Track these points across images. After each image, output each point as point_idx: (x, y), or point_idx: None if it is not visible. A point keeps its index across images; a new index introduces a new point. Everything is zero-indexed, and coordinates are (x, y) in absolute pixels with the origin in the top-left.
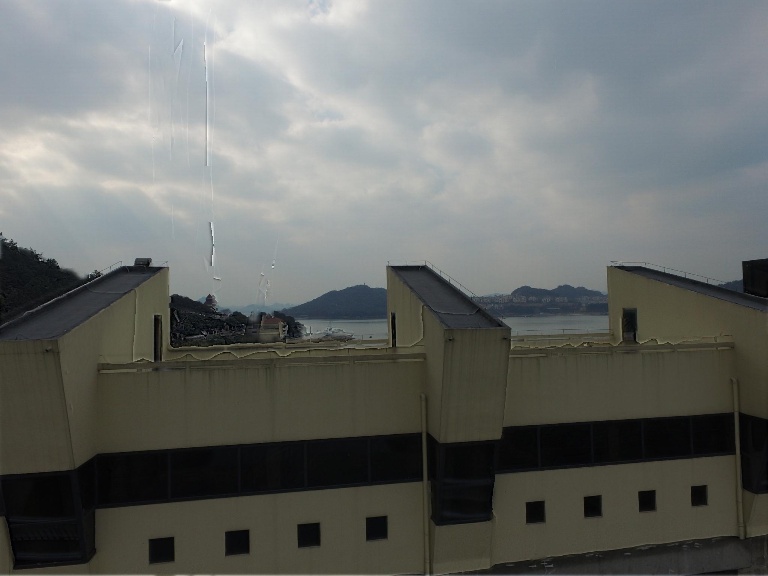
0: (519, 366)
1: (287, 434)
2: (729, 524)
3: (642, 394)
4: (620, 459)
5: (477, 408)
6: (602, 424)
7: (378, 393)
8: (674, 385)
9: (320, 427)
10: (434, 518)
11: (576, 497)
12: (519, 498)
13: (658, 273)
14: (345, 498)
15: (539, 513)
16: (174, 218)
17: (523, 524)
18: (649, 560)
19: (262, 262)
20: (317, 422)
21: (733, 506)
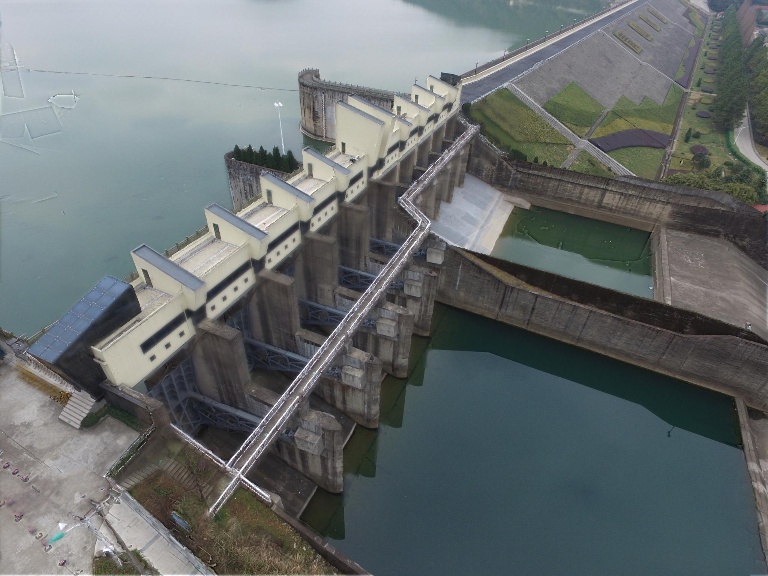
0: None
1: None
2: None
3: None
4: None
5: None
6: None
7: None
8: None
9: None
10: (434, 123)
11: (439, 117)
12: None
13: None
14: None
15: None
16: None
17: None
18: None
19: None
20: None
21: None
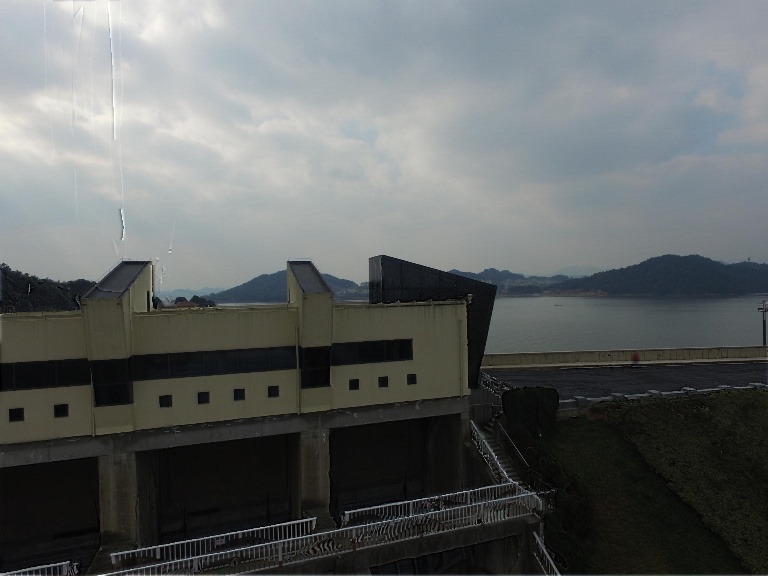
0: (156, 321)
1: (1, 359)
2: (293, 407)
3: (238, 336)
4: (223, 372)
5: (109, 341)
6: (211, 353)
7: (62, 336)
8: (259, 331)
9: (23, 355)
10: None
11: (193, 393)
12: (155, 394)
13: (310, 266)
14: (40, 394)
15: (169, 402)
16: (78, 198)
17: (157, 408)
18: (243, 427)
19: (157, 247)
20: (21, 353)
21: (295, 397)
